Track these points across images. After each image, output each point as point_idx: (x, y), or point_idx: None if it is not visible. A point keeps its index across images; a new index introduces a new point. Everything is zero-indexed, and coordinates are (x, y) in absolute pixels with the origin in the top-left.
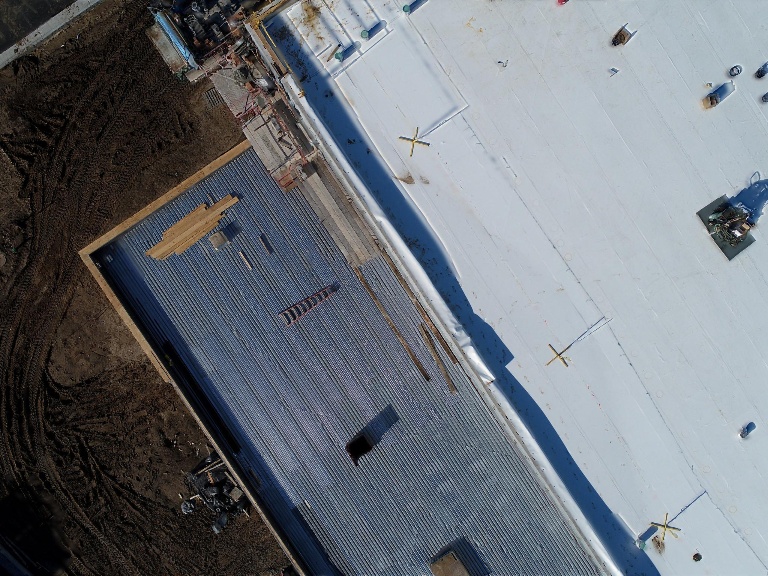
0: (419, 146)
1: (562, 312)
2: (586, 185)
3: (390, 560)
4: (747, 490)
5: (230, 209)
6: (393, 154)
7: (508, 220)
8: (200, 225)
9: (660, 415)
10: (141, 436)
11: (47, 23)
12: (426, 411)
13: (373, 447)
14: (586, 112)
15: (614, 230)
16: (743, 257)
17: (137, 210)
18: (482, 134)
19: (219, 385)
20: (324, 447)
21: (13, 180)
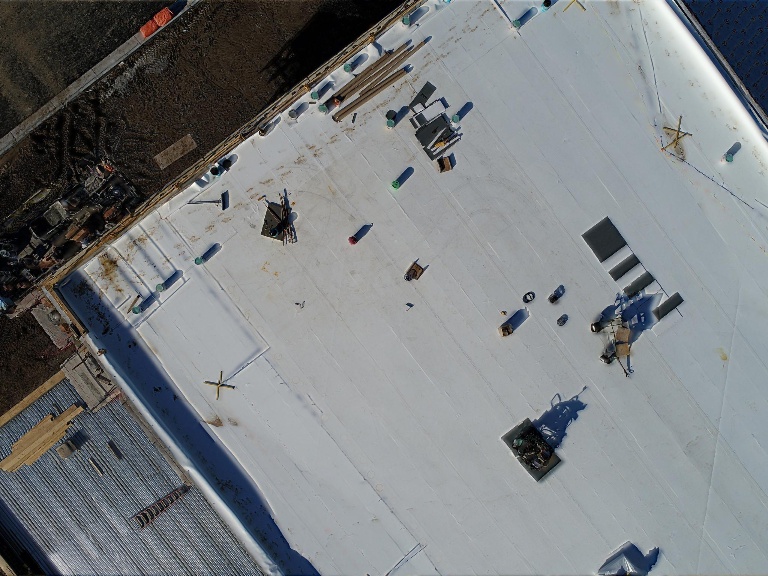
0: (224, 389)
1: (377, 542)
2: (391, 417)
3: None
4: None
5: (76, 418)
6: (200, 398)
7: (318, 455)
8: (47, 436)
9: None
10: None
11: None
12: None
13: None
14: (385, 347)
15: (422, 459)
16: (550, 477)
17: (6, 395)
18: (285, 374)
19: None
20: None
21: None
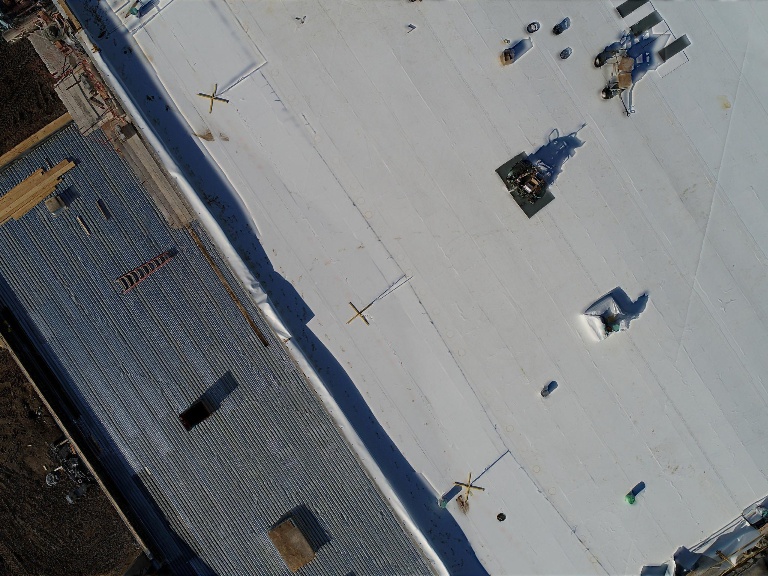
0: (218, 103)
1: (363, 270)
2: (385, 142)
3: (231, 527)
4: (550, 449)
5: (67, 174)
6: (192, 111)
7: (308, 177)
8: (36, 190)
9: (462, 374)
10: (5, 407)
11: None
12: (265, 377)
13: (213, 414)
14: (384, 69)
15: (414, 187)
16: (543, 215)
17: None
18: (281, 91)
19: (58, 351)
20: (164, 414)
21: None
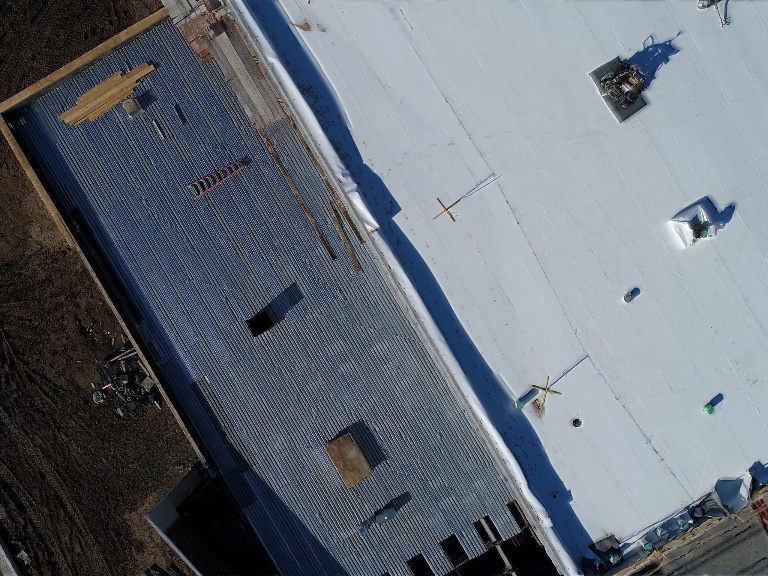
0: None
1: (452, 167)
2: (481, 41)
3: (288, 441)
4: (630, 357)
5: (146, 78)
6: (291, 0)
7: (402, 72)
8: (115, 91)
9: (545, 276)
10: (57, 322)
11: None
12: (331, 291)
13: (276, 325)
14: None
15: (507, 87)
16: (634, 120)
17: None
18: None
19: (125, 254)
20: (227, 322)
21: None
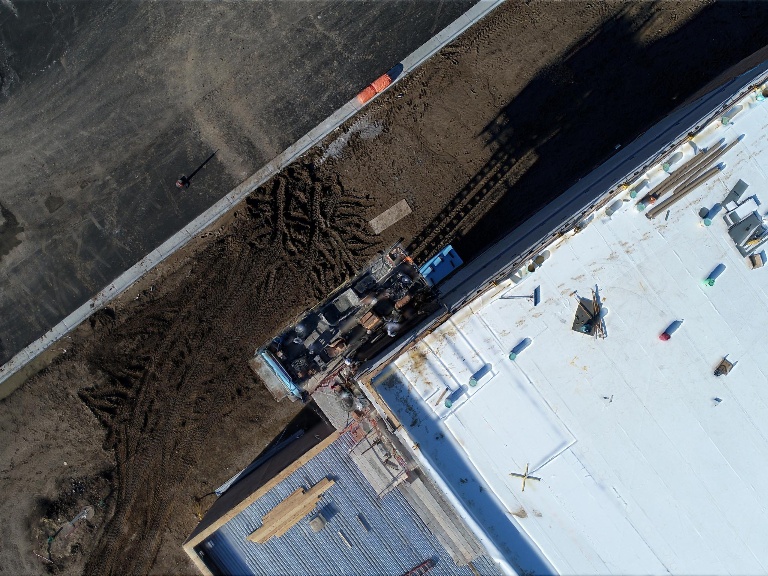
0: (530, 481)
1: None
2: (696, 510)
3: None
4: None
5: (327, 491)
6: (505, 490)
7: (621, 547)
8: (298, 509)
9: None
10: None
11: (121, 277)
12: None
13: None
14: (692, 441)
15: (726, 552)
16: None
17: (220, 456)
18: (591, 467)
19: None
20: None
21: (97, 432)
